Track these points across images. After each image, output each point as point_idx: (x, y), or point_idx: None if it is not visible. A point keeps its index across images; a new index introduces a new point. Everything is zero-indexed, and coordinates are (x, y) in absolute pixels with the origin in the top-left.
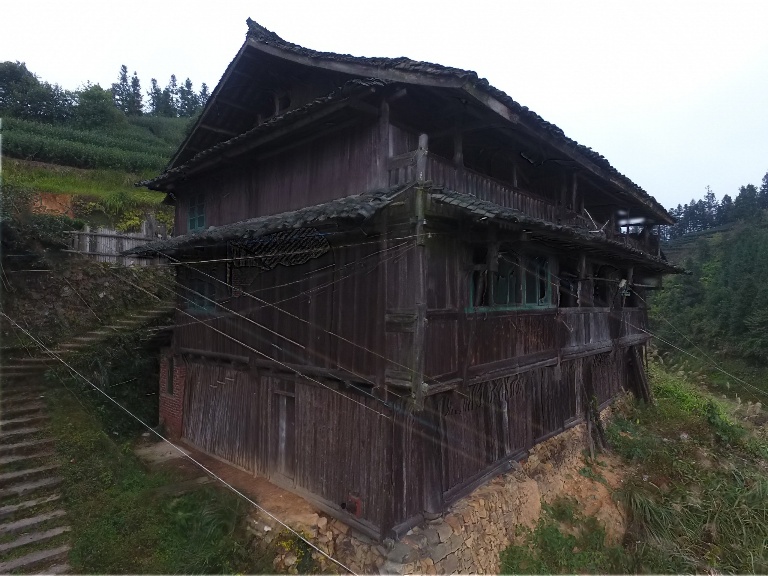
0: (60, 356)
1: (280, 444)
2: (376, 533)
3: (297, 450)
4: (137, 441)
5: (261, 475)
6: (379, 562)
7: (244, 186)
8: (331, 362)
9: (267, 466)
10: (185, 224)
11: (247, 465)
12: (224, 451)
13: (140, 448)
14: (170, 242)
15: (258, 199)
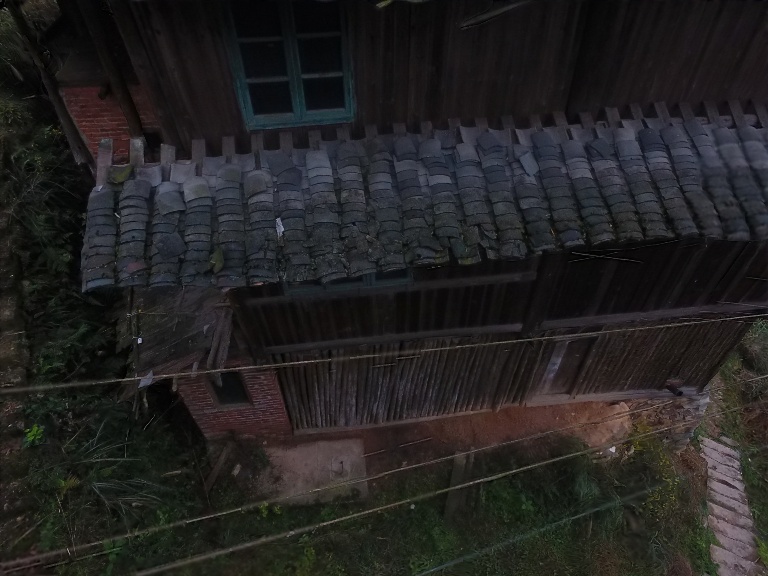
0: (3, 564)
1: (546, 376)
2: (694, 392)
3: (587, 374)
4: (244, 488)
5: (508, 406)
6: (686, 403)
7: (566, 5)
8: (708, 300)
9: (523, 398)
10: (222, 98)
11: (480, 408)
12: (426, 412)
13: (276, 491)
14: (414, 227)
15: (624, 58)
